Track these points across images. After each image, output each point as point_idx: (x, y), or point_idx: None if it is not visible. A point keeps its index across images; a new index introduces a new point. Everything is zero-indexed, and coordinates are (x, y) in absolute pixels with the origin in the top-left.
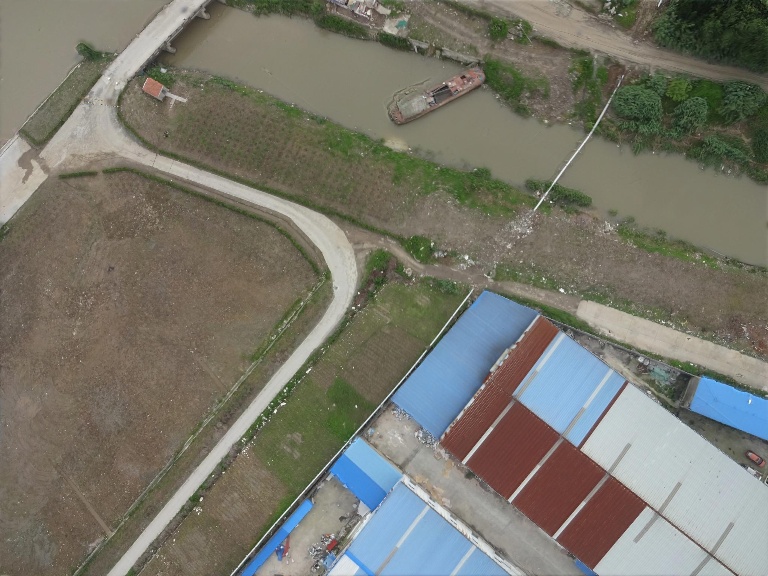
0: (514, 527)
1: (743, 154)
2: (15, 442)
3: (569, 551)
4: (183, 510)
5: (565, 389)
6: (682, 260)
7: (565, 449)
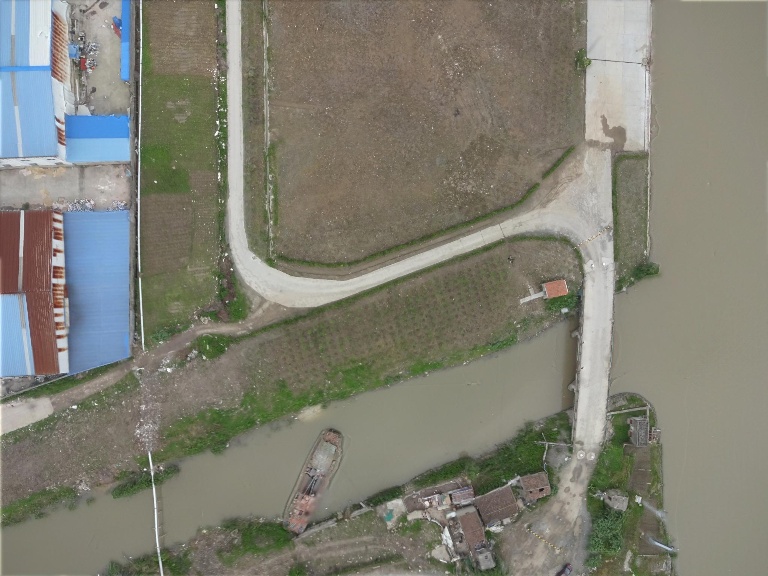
0: None
1: None
2: None
3: None
4: None
5: None
6: (3, 508)
7: None
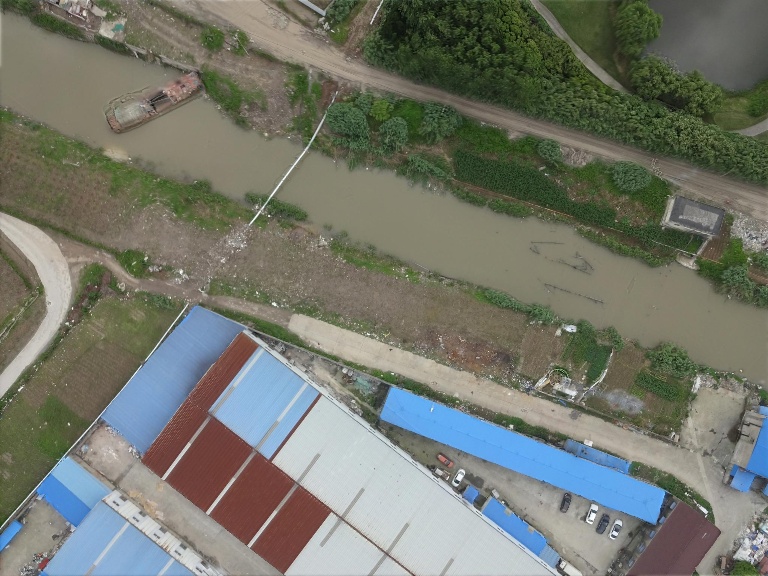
0: (225, 535)
1: (445, 173)
2: None
3: None
4: None
5: (260, 404)
6: (386, 275)
7: (257, 462)
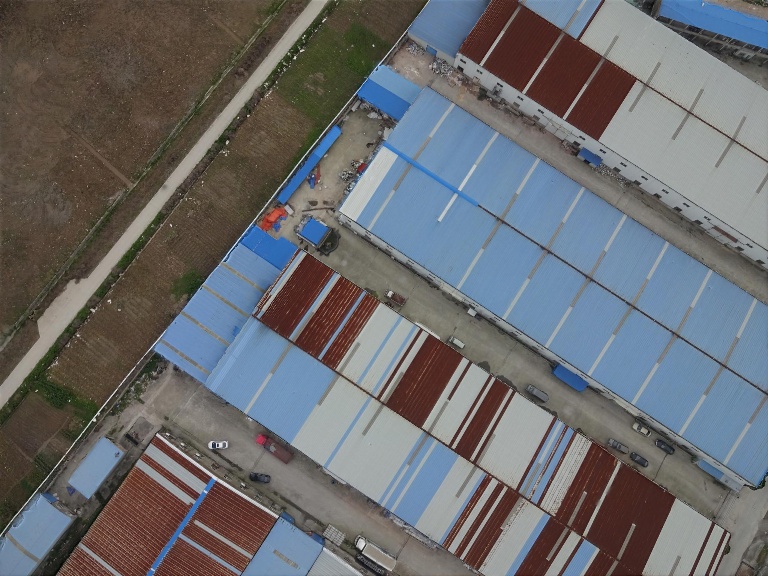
0: (524, 136)
1: None
2: (15, 107)
3: (577, 128)
4: (210, 152)
5: None
6: None
7: (567, 41)
